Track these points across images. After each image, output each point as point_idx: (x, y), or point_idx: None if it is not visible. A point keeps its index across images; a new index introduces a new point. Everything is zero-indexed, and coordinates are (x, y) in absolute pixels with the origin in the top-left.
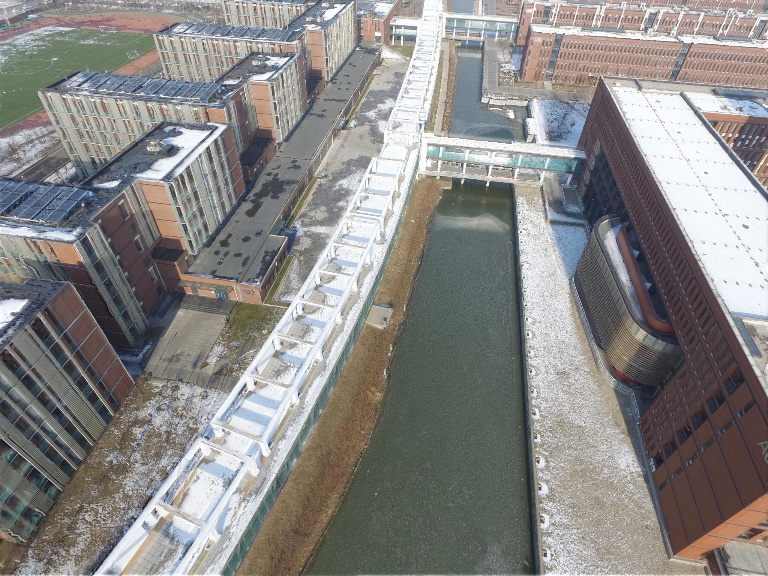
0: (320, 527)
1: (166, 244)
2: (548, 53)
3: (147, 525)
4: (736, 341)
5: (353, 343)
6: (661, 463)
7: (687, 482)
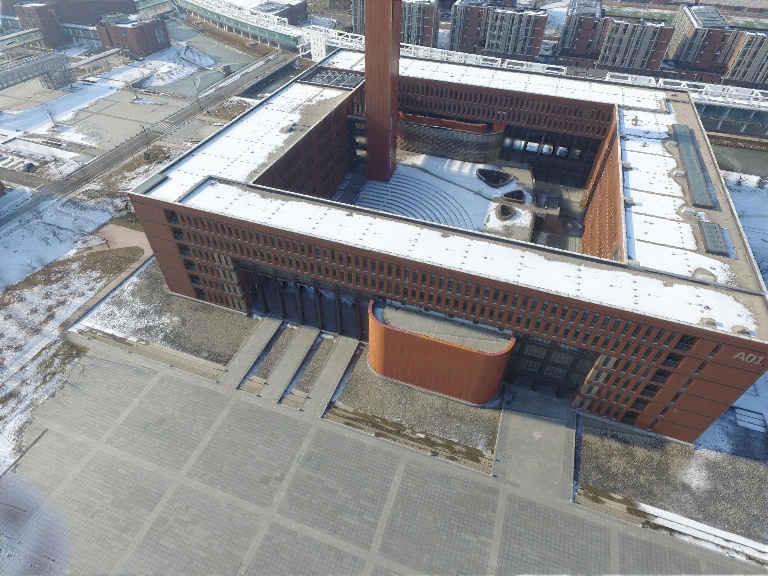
0: None
1: None
2: None
3: None
4: None
5: None
6: None
7: None
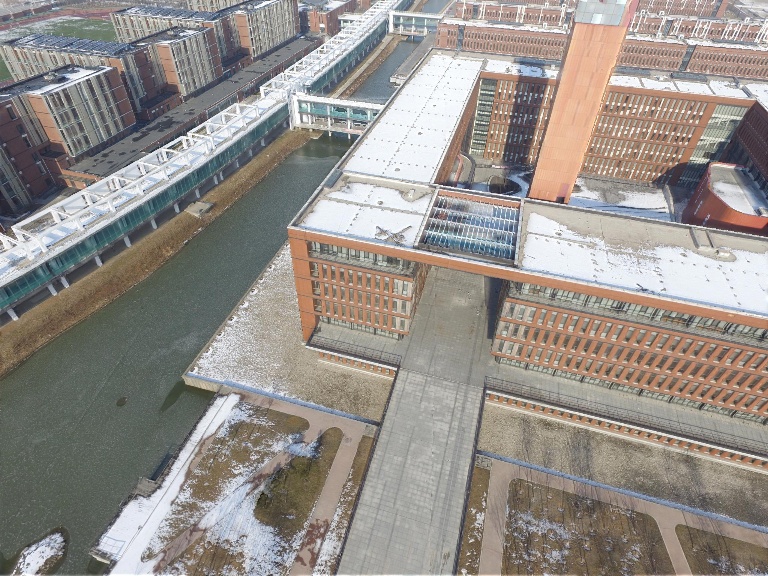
0: (87, 313)
1: (54, 148)
2: (454, 42)
3: None
4: None
5: (155, 213)
6: None
7: None
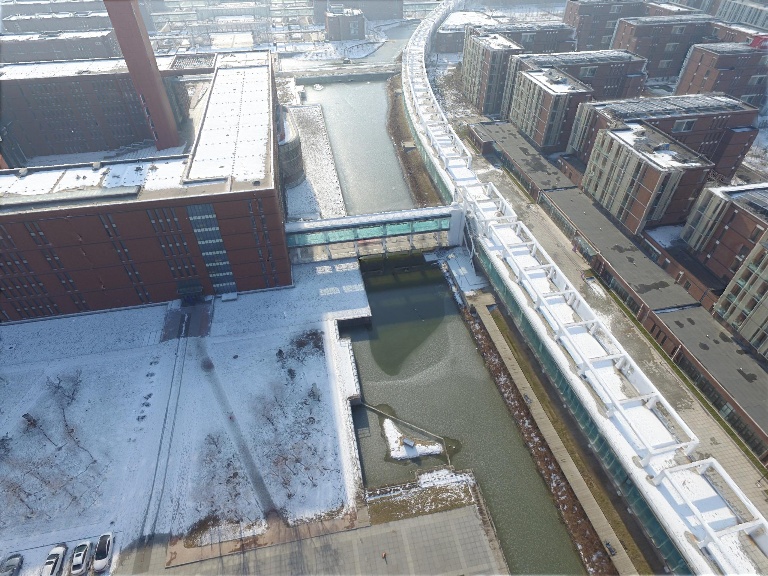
0: None
1: None
2: None
3: None
4: None
5: None
6: None
7: None
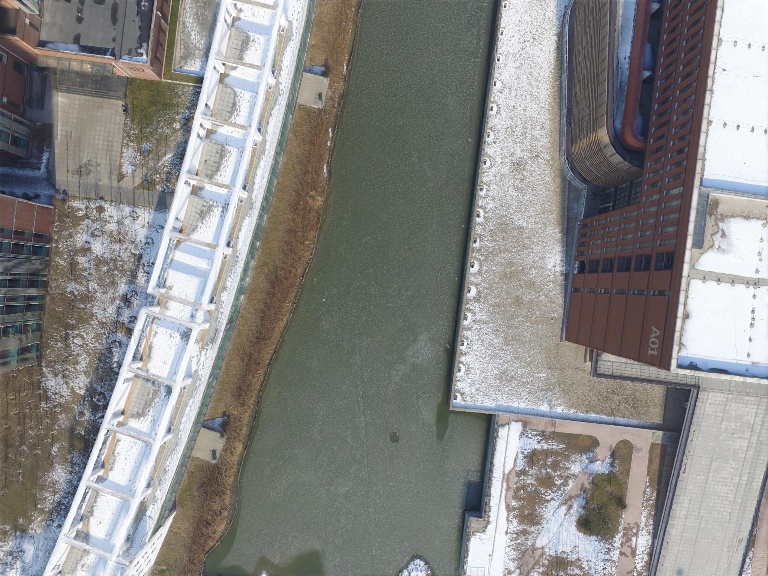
0: (278, 331)
1: None
2: None
3: (127, 378)
4: (686, 227)
5: (281, 153)
6: (584, 268)
7: (593, 305)
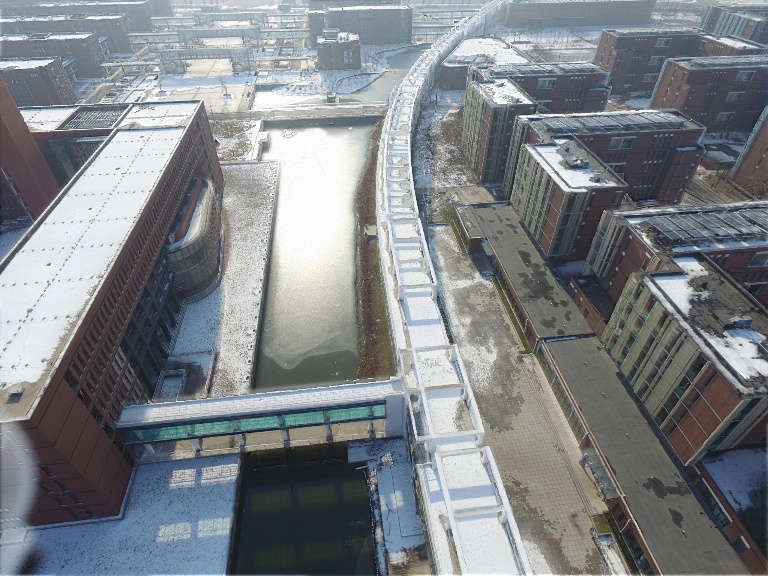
0: None
1: None
2: None
3: None
4: None
5: None
6: None
7: None
